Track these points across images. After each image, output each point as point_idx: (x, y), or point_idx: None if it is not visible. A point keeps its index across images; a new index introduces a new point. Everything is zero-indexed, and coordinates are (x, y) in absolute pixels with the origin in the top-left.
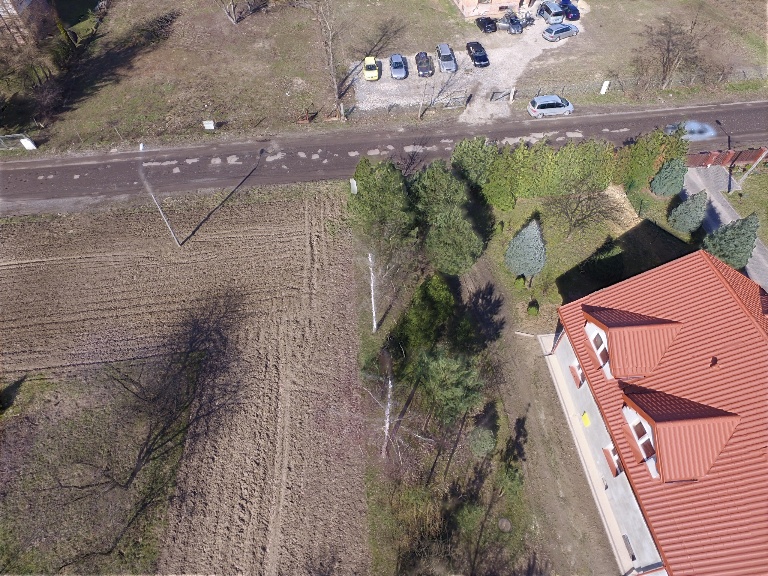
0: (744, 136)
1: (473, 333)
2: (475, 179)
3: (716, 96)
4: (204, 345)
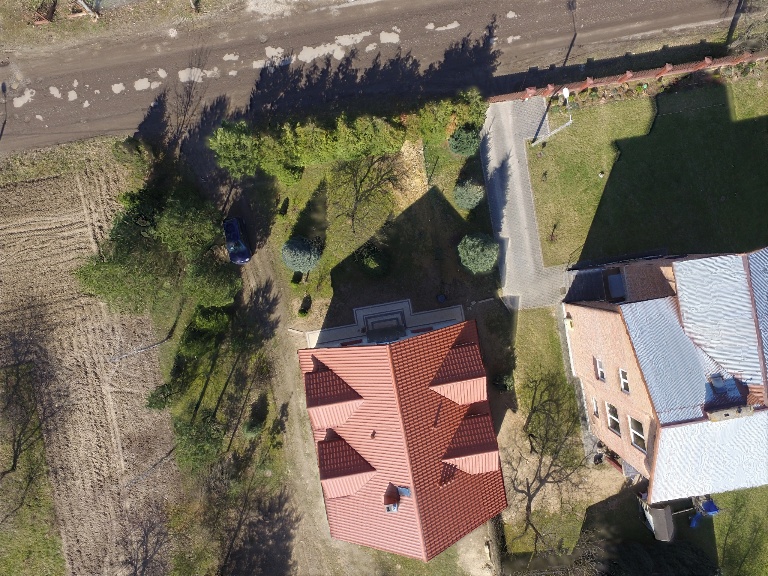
0: (593, 33)
1: (252, 334)
2: None
3: None
4: (28, 357)
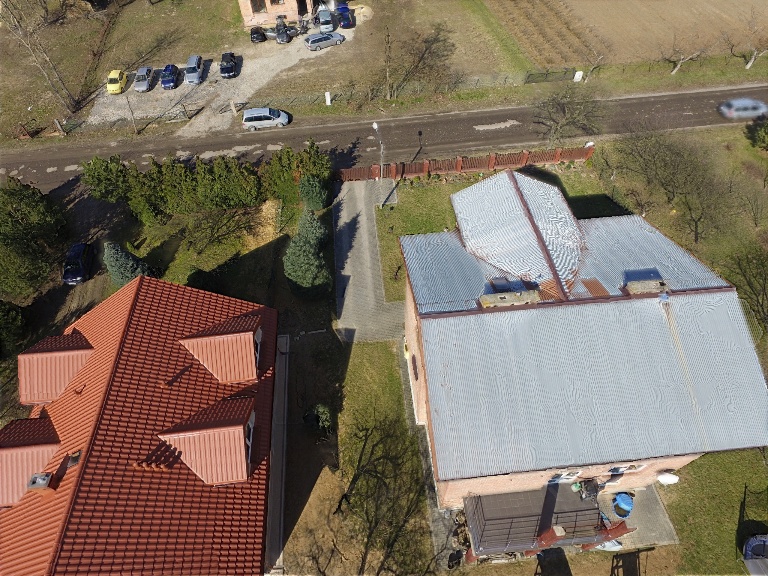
0: (436, 147)
1: None
2: (105, 197)
3: (437, 106)
4: None
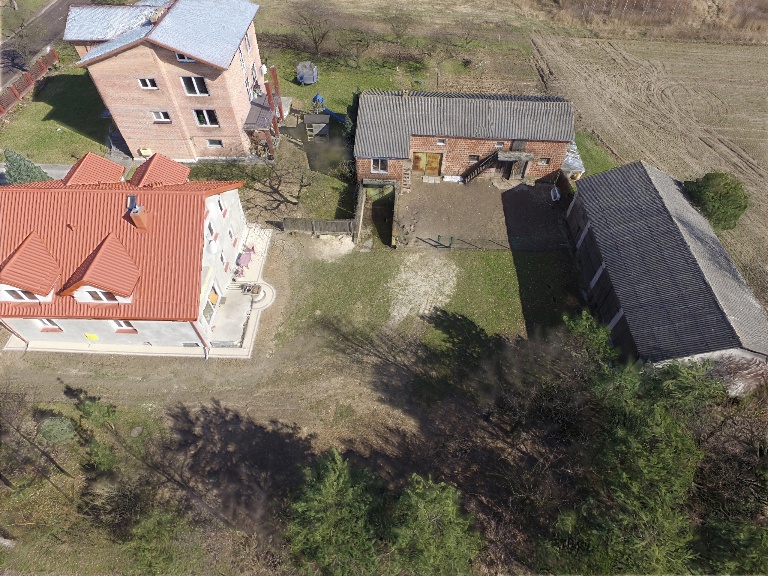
0: None
1: None
2: None
3: None
4: None
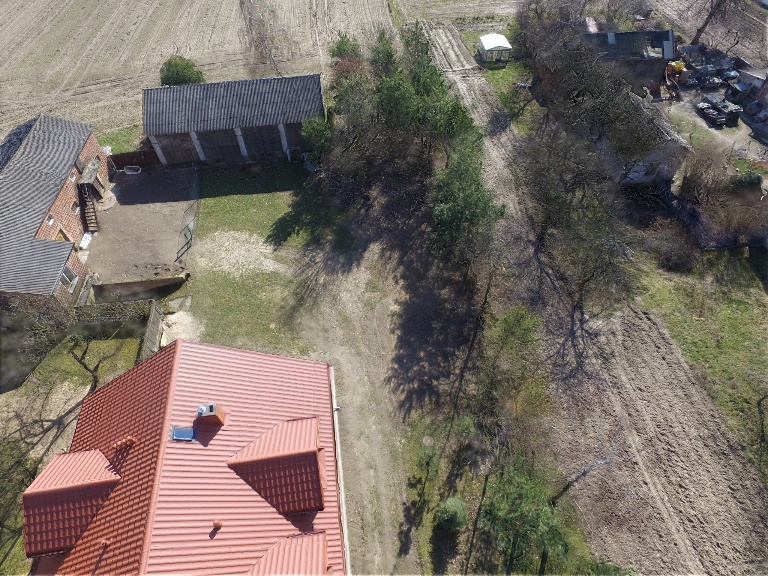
0: None
1: None
2: None
3: None
4: None
